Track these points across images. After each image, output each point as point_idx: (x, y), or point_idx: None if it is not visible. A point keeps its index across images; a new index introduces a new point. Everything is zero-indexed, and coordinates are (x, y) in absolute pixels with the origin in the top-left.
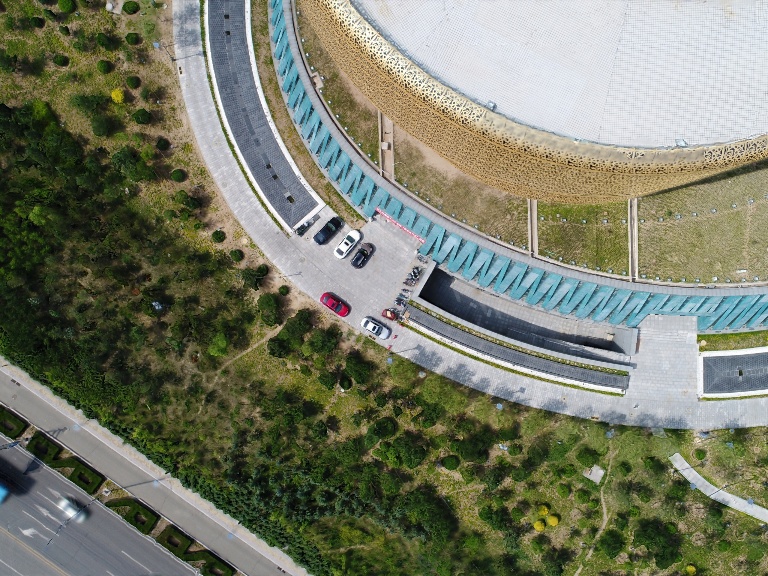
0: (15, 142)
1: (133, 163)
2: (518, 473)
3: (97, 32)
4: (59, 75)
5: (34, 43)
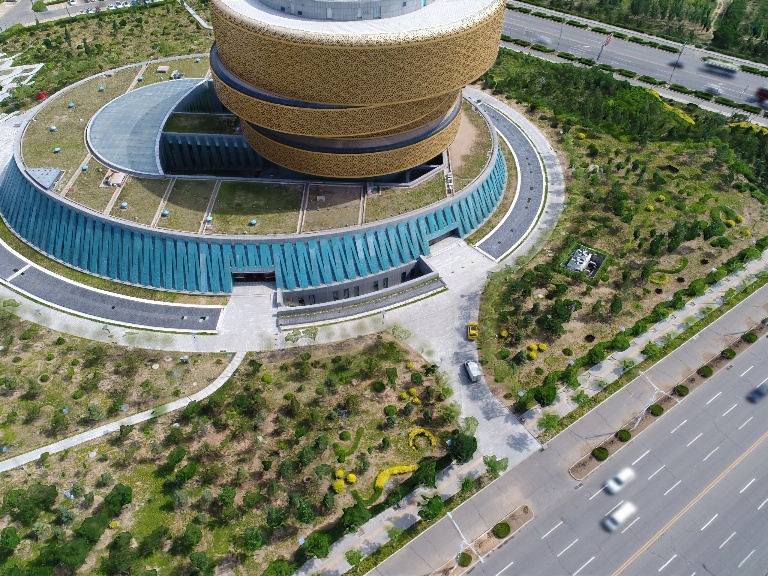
0: None
1: None
2: None
3: None
4: None
5: None
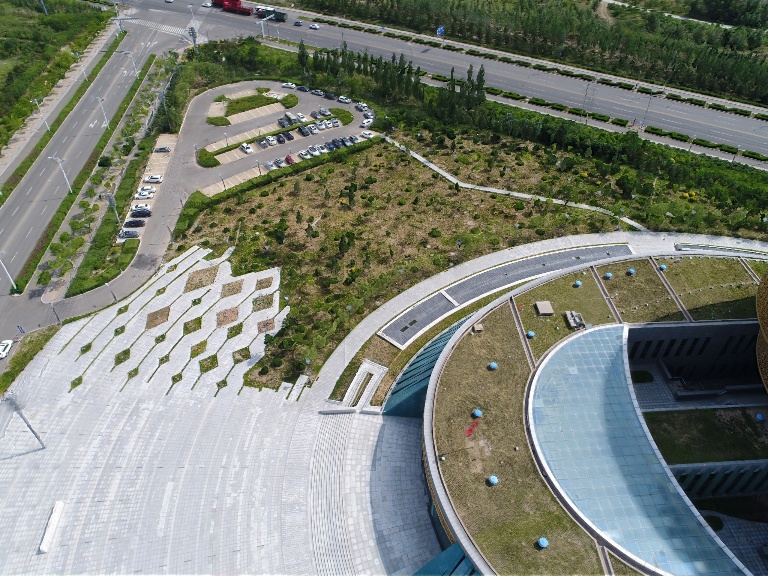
0: None
1: None
2: None
3: None
4: None
5: None
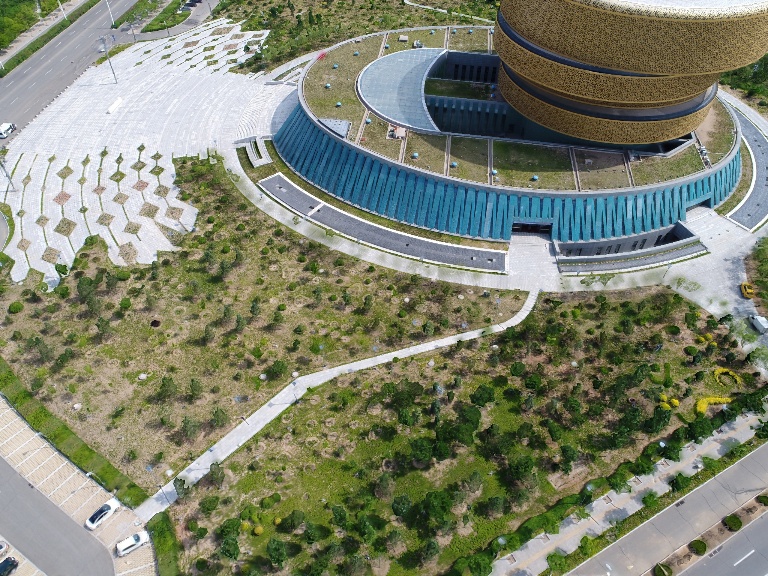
0: None
1: None
2: None
3: None
4: None
5: None
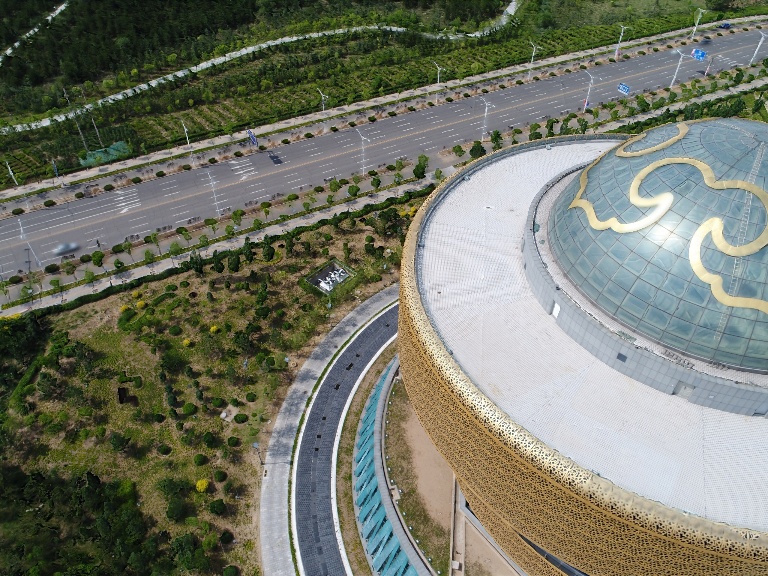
0: (86, 514)
1: (191, 551)
2: None
3: (205, 432)
4: (157, 461)
5: (148, 433)
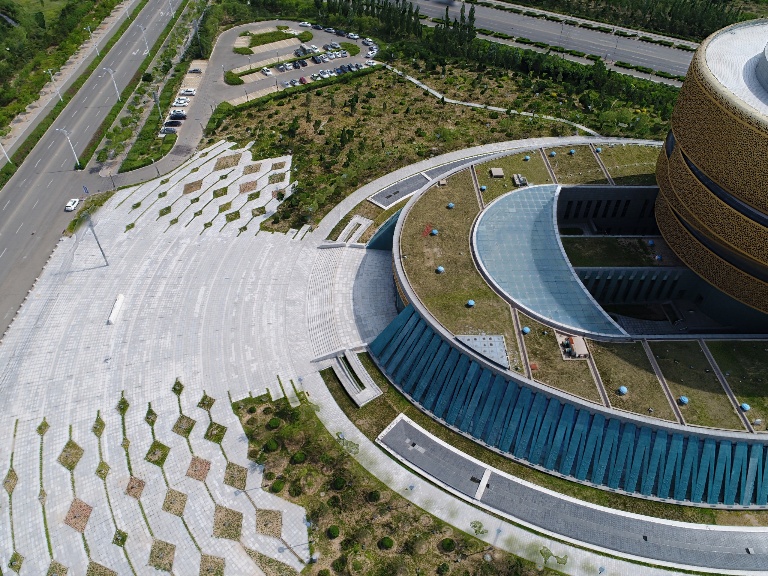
0: None
1: None
2: (669, 116)
3: None
4: None
5: None
